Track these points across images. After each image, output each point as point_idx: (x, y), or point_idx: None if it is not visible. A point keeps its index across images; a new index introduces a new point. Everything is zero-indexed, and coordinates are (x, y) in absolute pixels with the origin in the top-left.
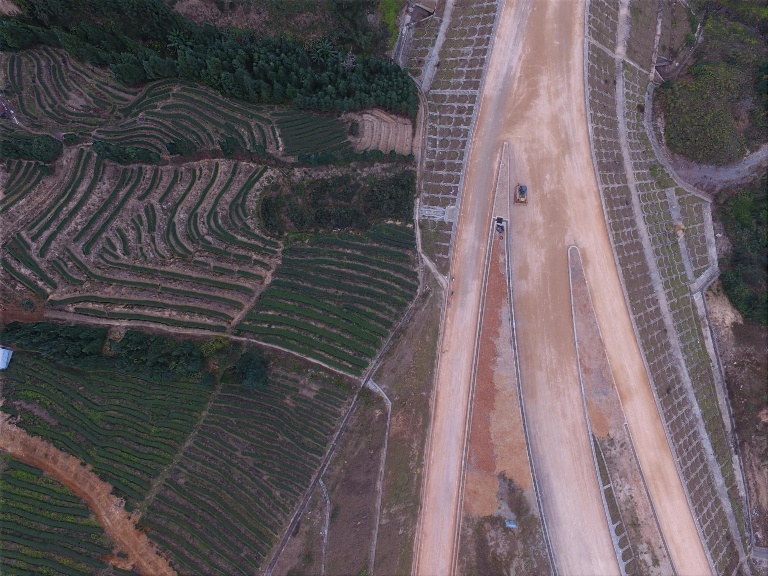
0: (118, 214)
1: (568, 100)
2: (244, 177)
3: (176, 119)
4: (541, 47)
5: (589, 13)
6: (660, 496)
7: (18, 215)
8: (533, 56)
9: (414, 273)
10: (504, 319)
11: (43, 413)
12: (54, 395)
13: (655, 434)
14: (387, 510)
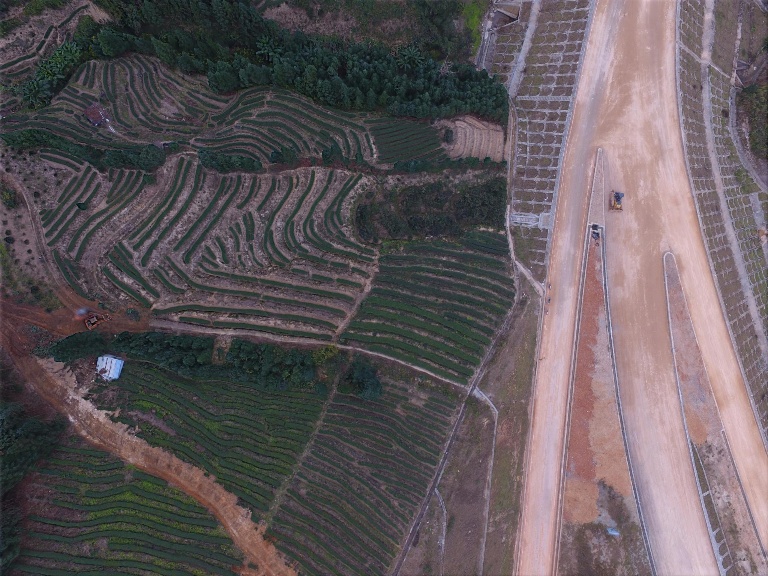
0: (217, 223)
1: (660, 106)
2: (339, 185)
3: (272, 127)
4: (633, 53)
5: (680, 18)
6: (757, 503)
7: (119, 224)
8: (625, 62)
9: (510, 280)
10: (601, 326)
11: (160, 423)
12: (169, 405)
13: (752, 441)
14: (493, 518)
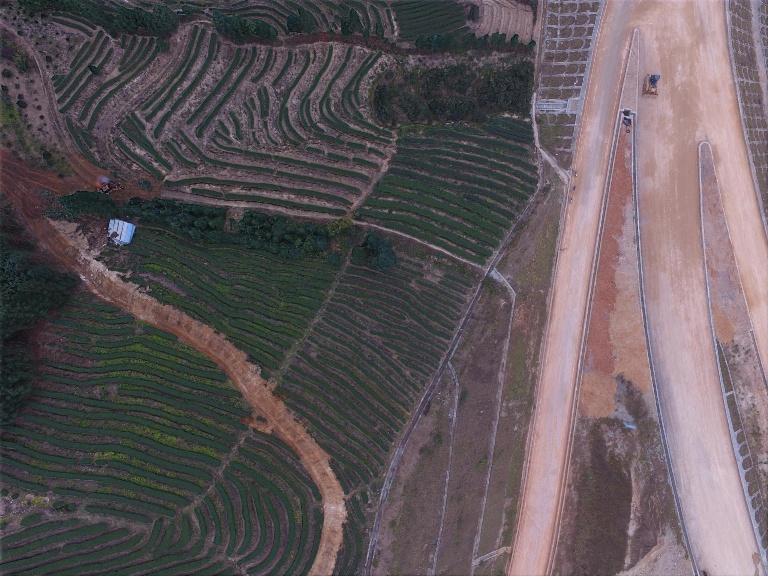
0: (231, 96)
1: None
2: (358, 63)
3: None
4: None
5: None
6: None
7: (132, 94)
8: None
9: (534, 167)
10: (628, 217)
11: (171, 285)
12: (180, 268)
13: None
14: (506, 403)
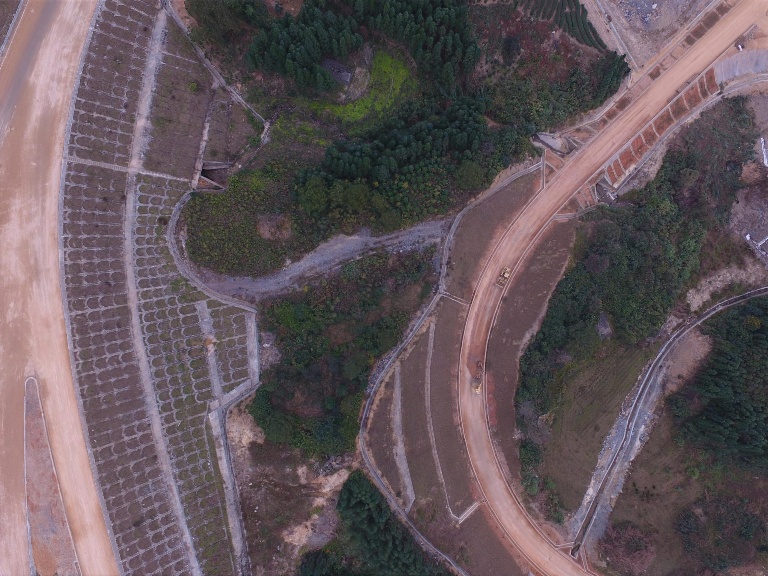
0: None
1: (41, 224)
2: None
3: None
4: (16, 169)
5: (72, 132)
6: None
7: None
8: (6, 178)
9: None
10: None
11: None
12: None
13: (109, 572)
14: None
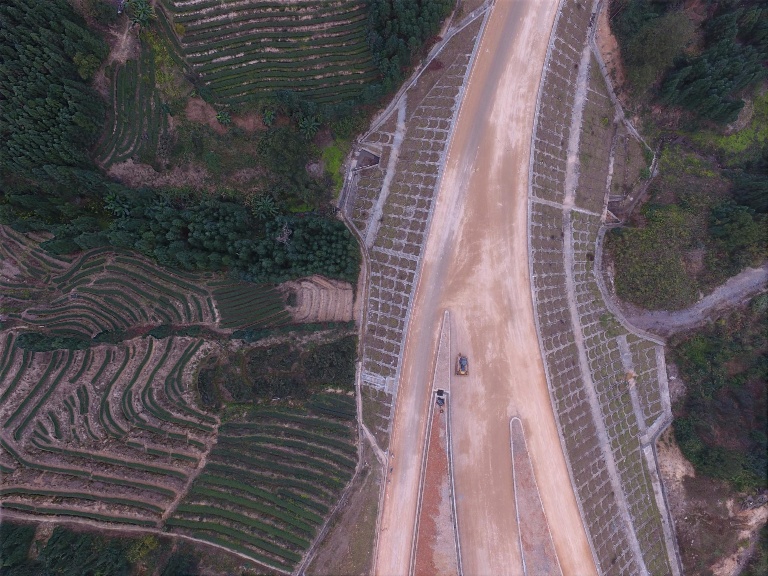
0: (49, 397)
1: (511, 264)
2: (180, 351)
3: (109, 295)
4: (484, 210)
5: (533, 172)
6: None
7: None
8: (475, 219)
9: (353, 448)
10: (444, 496)
11: None
12: None
13: None
14: None
